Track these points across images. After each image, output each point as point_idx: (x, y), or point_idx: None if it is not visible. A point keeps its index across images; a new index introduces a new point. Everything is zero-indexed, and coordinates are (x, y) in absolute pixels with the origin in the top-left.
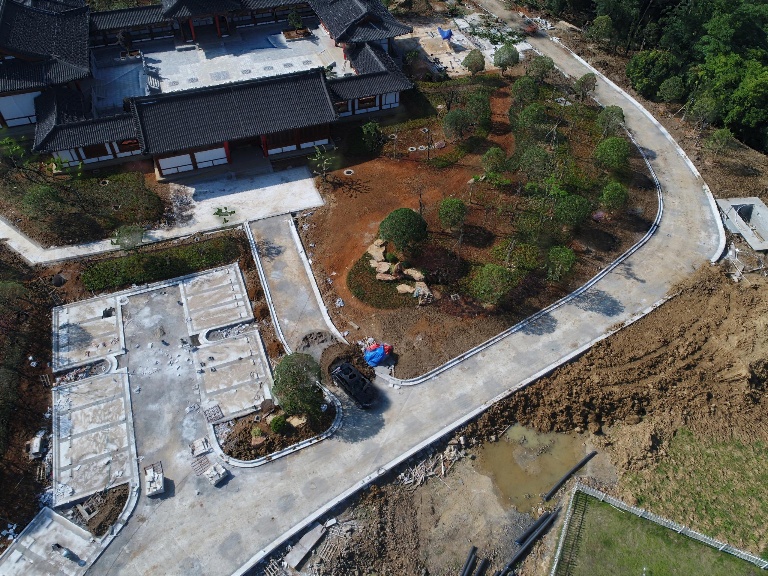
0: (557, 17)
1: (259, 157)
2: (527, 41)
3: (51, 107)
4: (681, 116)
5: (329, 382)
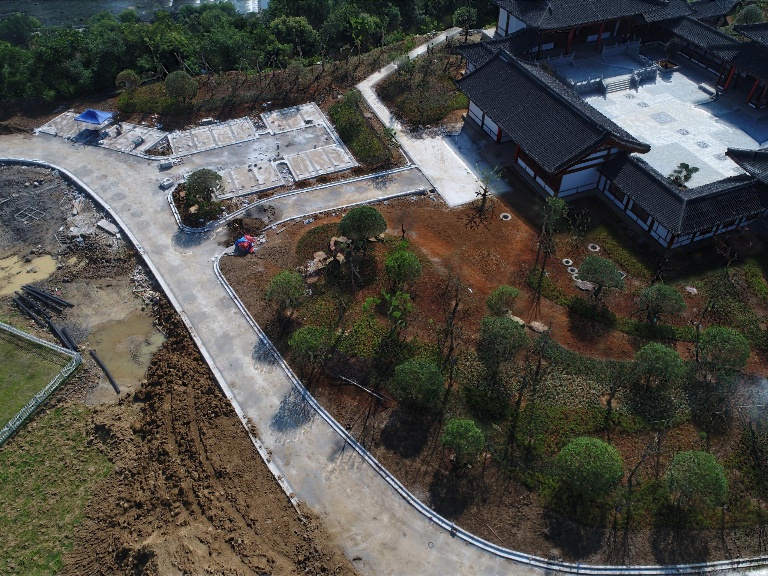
0: None
1: (513, 158)
2: None
3: None
4: None
5: None
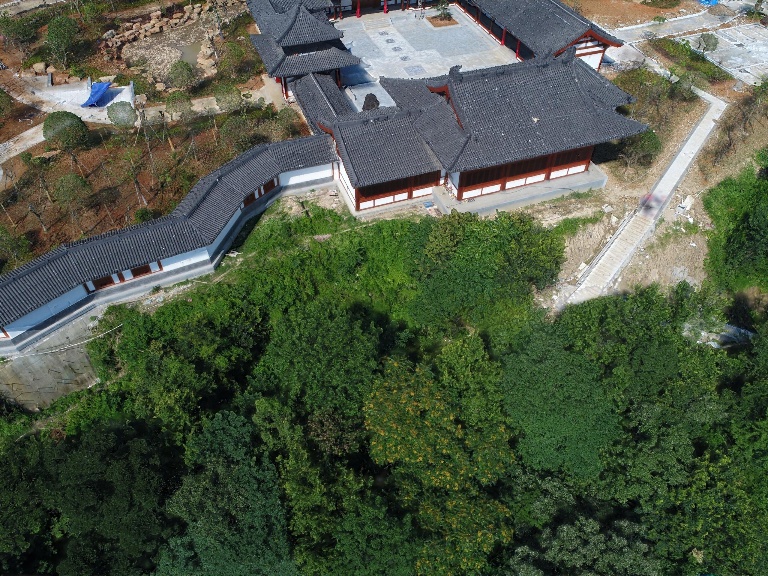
0: None
1: None
2: None
3: None
4: None
5: None
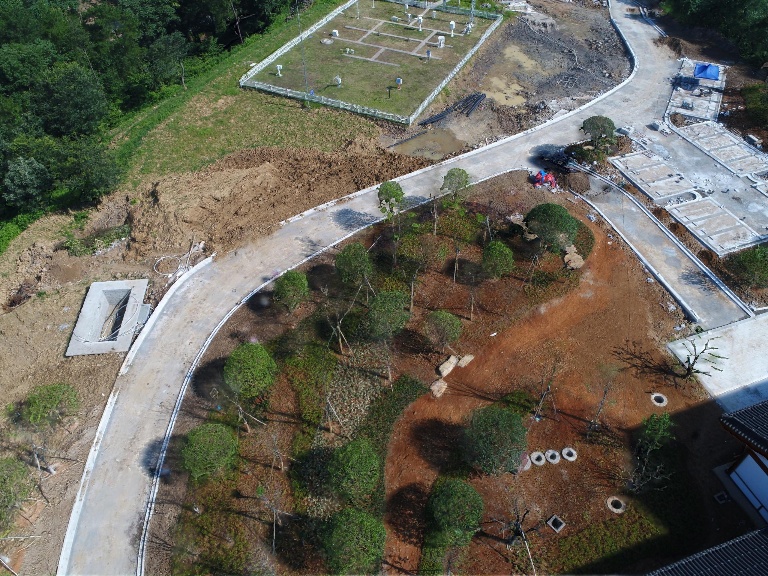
0: None
1: None
2: None
3: None
4: None
5: None
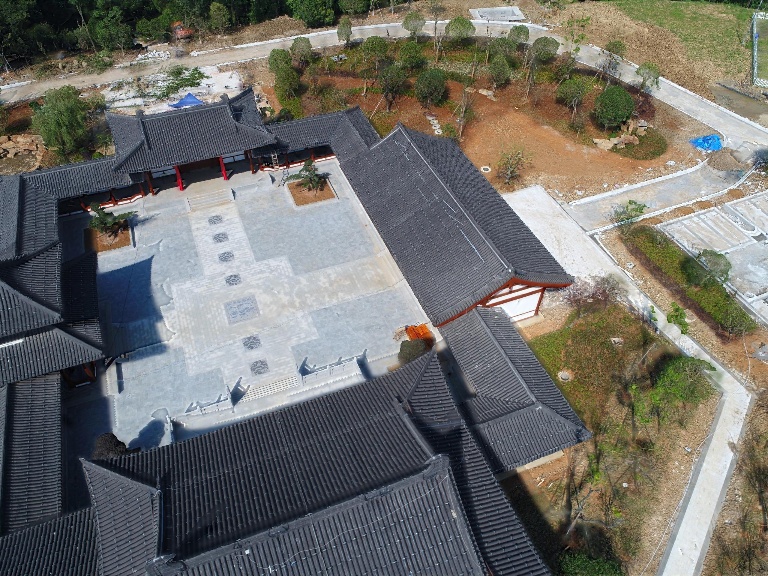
0: None
1: None
2: None
3: None
4: (363, 17)
5: (747, 166)
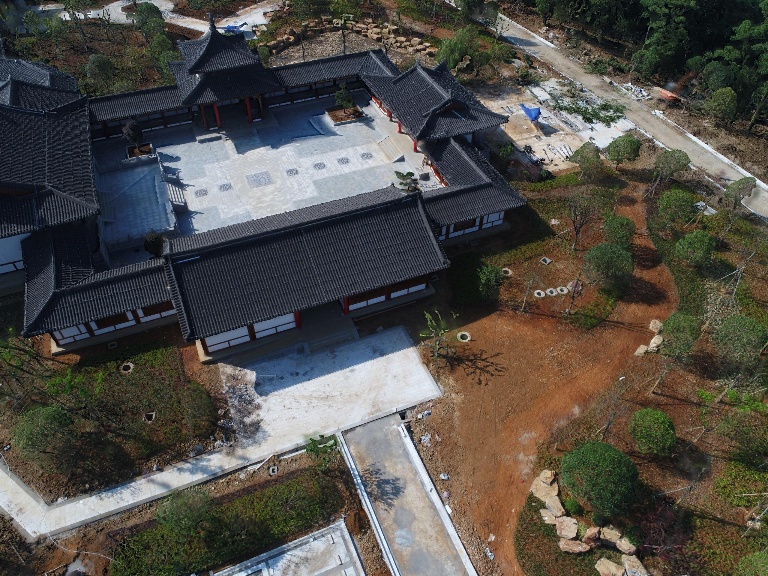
0: (647, 81)
1: (336, 314)
2: (626, 117)
3: (46, 256)
4: None
5: None
